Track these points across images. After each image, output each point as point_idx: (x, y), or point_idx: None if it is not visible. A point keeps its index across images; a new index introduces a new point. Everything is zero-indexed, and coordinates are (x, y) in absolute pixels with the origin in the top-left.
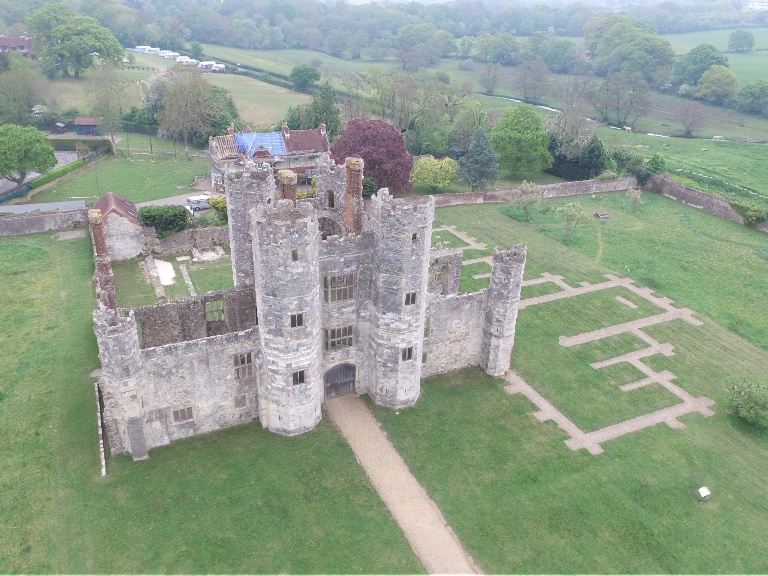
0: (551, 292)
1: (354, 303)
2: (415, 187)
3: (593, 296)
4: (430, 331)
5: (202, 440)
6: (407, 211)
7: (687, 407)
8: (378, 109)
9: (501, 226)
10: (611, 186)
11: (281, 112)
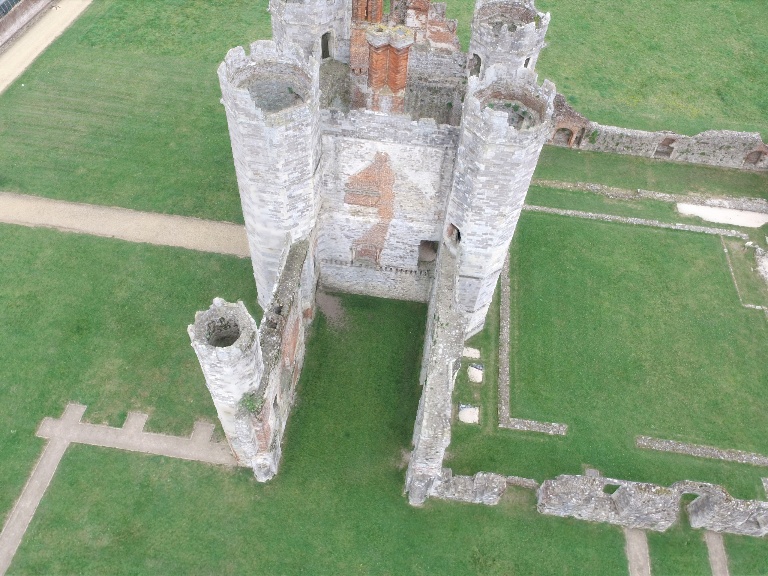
0: None
1: None
2: None
3: None
4: None
5: None
6: None
7: None
8: None
9: None
10: None
11: None
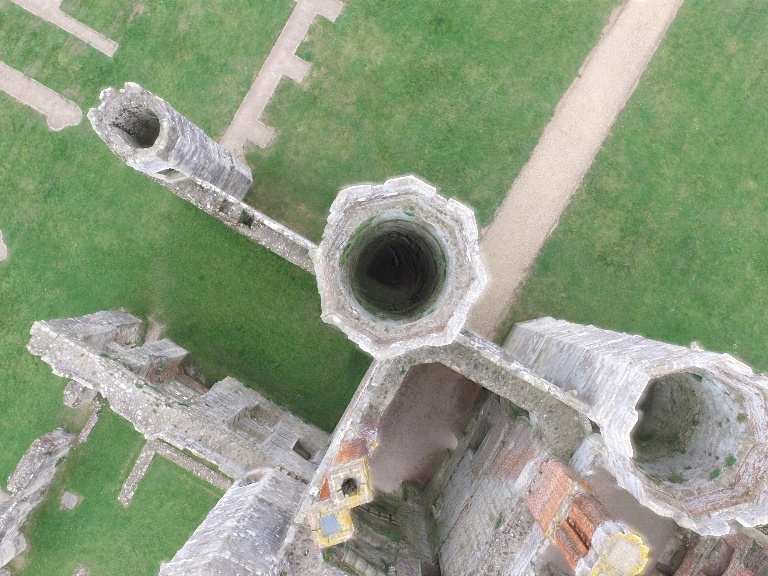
0: None
1: None
2: None
3: None
4: None
5: None
6: None
7: None
8: None
9: None
10: None
11: None
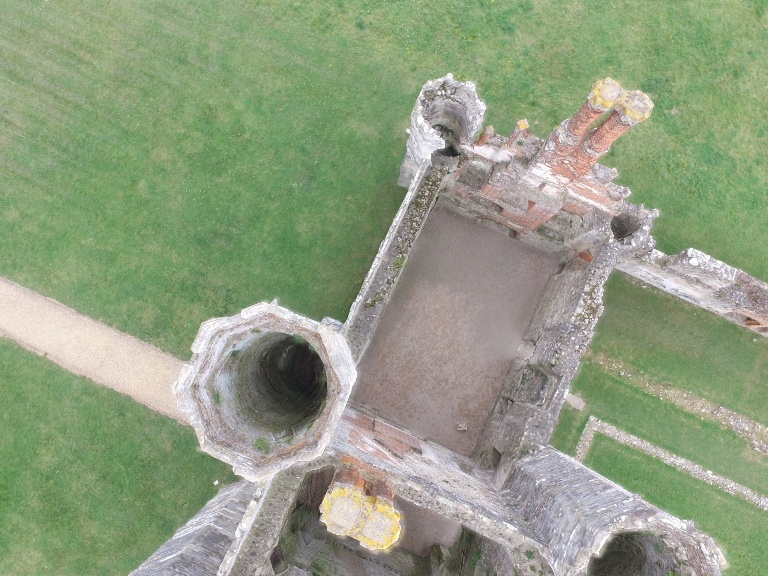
0: None
1: None
2: None
3: None
4: None
5: None
6: None
7: None
8: None
9: None
10: None
11: None
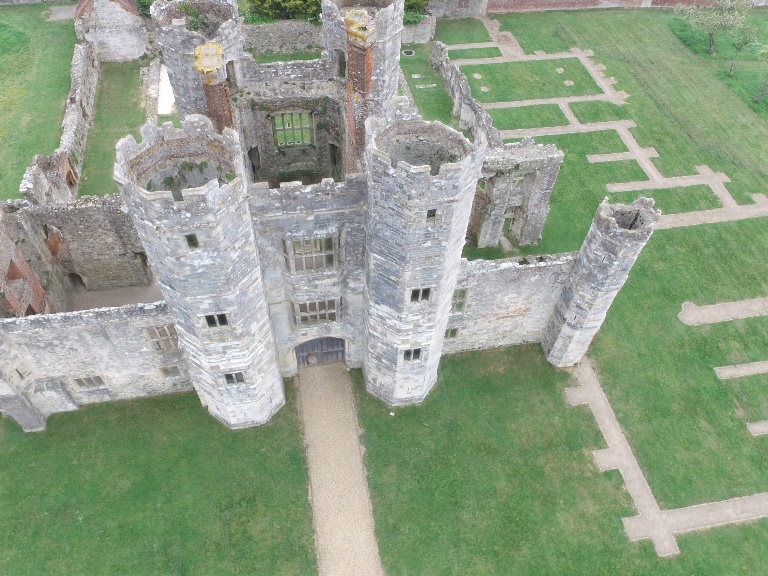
0: (699, 208)
1: (335, 274)
2: None
3: (764, 226)
4: (465, 305)
5: (119, 411)
6: (417, 175)
7: None
8: None
9: (663, 59)
10: None
11: None
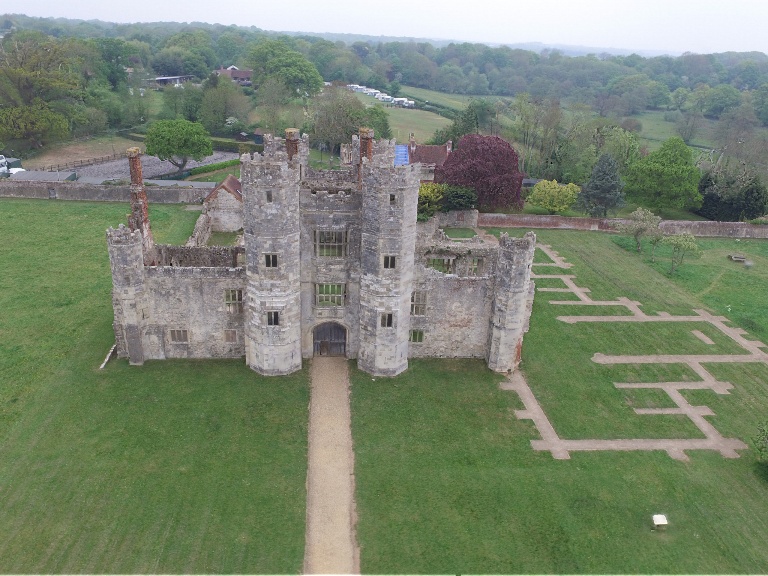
0: (616, 314)
1: (343, 262)
2: (533, 210)
3: (664, 325)
4: (426, 308)
5: (192, 362)
6: (384, 170)
7: (706, 444)
8: (519, 135)
9: (602, 252)
10: (767, 233)
11: (428, 134)
